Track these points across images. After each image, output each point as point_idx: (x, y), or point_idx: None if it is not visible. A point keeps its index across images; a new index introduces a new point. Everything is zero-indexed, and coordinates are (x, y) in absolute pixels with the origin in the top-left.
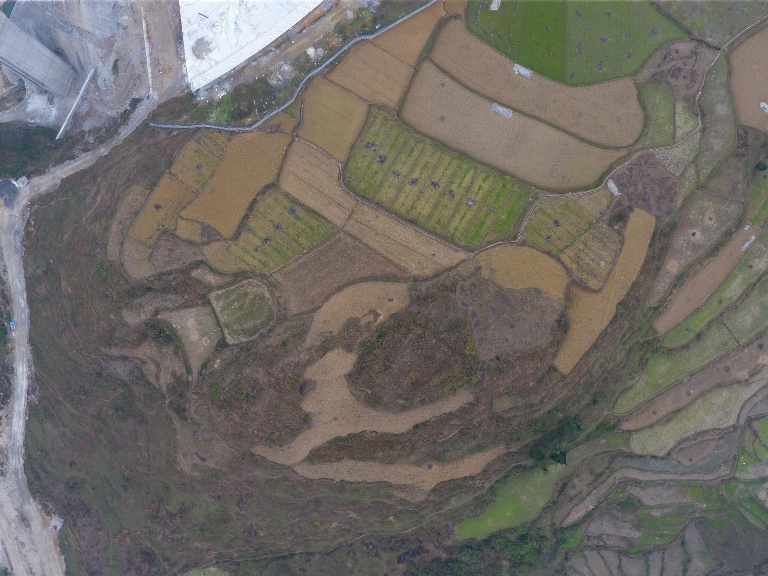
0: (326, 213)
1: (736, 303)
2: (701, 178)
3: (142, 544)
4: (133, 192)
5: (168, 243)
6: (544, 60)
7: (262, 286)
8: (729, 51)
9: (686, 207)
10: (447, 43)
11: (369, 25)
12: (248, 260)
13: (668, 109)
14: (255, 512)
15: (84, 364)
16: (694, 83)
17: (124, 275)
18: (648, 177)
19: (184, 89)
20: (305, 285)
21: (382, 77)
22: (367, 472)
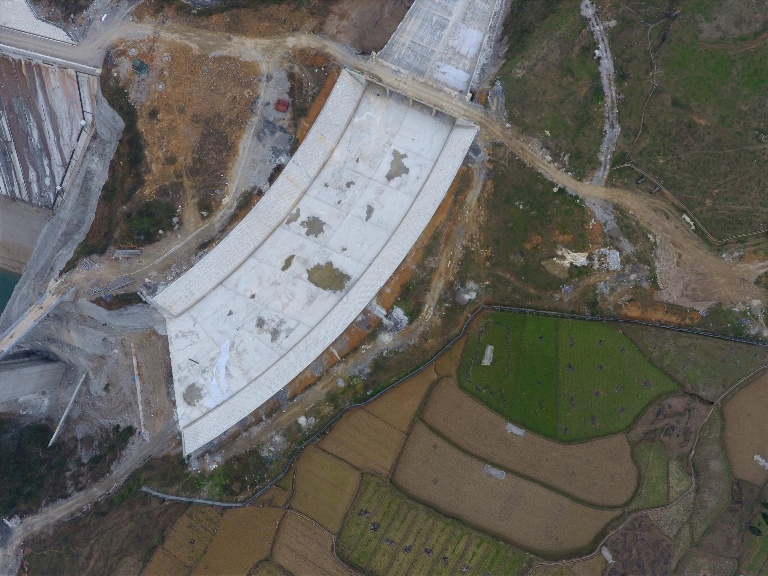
0: None
1: None
2: (695, 537)
3: None
4: (126, 564)
5: None
6: (537, 416)
7: None
8: (722, 404)
9: (681, 565)
10: (439, 402)
11: (360, 391)
12: None
13: (661, 468)
14: None
15: None
16: (687, 442)
17: None
18: (642, 541)
19: (176, 435)
20: None
21: (374, 444)
22: None
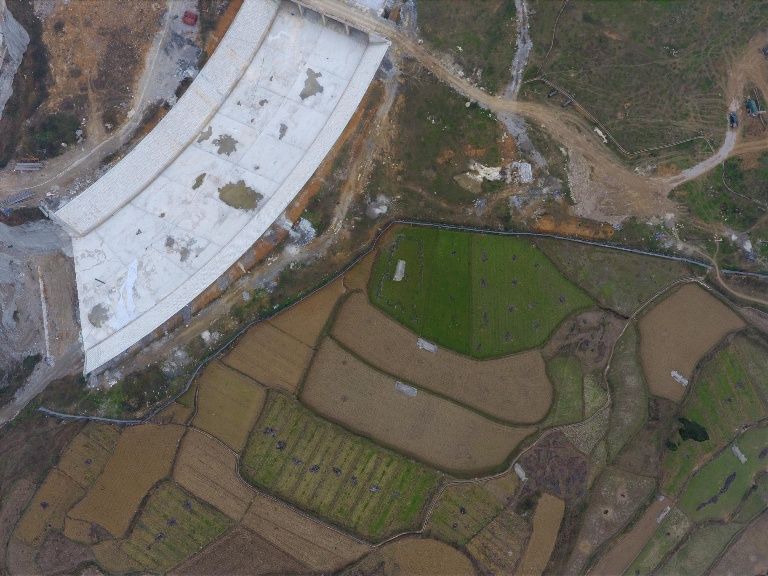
0: (222, 507)
1: (654, 573)
2: (612, 455)
3: None
4: (20, 486)
5: (56, 543)
6: (449, 332)
7: None
8: (638, 319)
9: (598, 484)
10: (349, 318)
11: (266, 305)
12: (141, 559)
13: (576, 384)
14: None
15: None
16: (602, 357)
17: None
18: (557, 458)
19: (80, 358)
20: None
21: (280, 360)
22: None
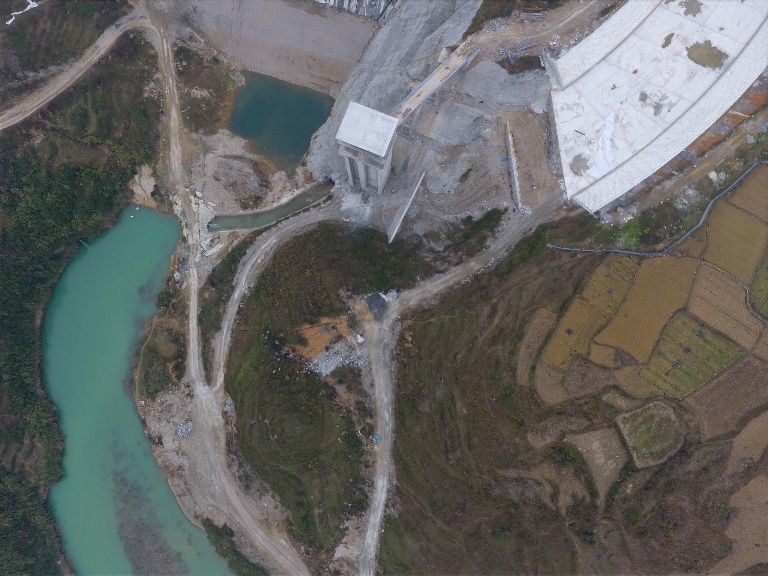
0: (735, 336)
1: None
2: None
3: None
4: (540, 315)
5: (580, 368)
6: None
7: (668, 408)
8: None
9: None
10: None
11: (767, 149)
12: (660, 384)
13: None
14: None
15: (476, 485)
16: None
17: (538, 401)
18: None
19: (561, 205)
20: (717, 409)
21: None
22: None
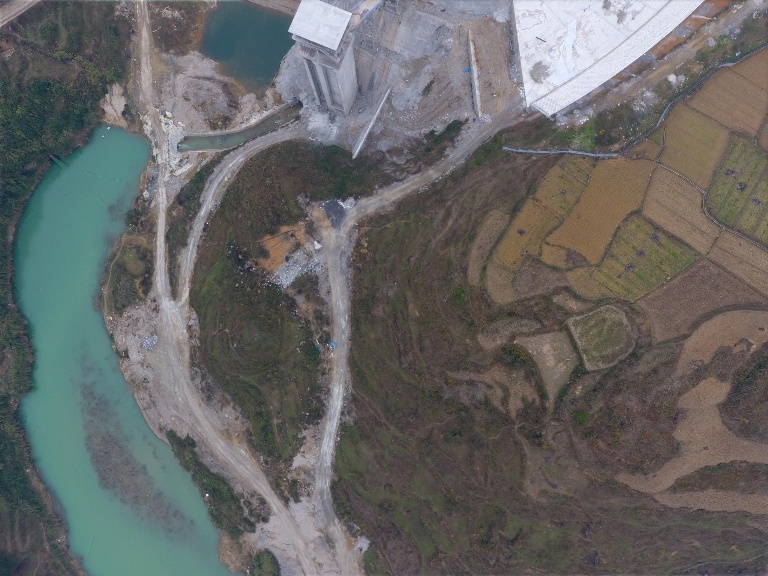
0: (690, 240)
1: None
2: None
3: (458, 568)
4: (492, 217)
5: (531, 268)
6: None
7: (620, 312)
8: None
9: None
10: None
11: (729, 52)
12: (612, 286)
13: None
14: (601, 539)
15: (427, 388)
16: None
17: (488, 300)
18: None
19: (521, 113)
20: (669, 312)
21: (742, 104)
22: (727, 501)
